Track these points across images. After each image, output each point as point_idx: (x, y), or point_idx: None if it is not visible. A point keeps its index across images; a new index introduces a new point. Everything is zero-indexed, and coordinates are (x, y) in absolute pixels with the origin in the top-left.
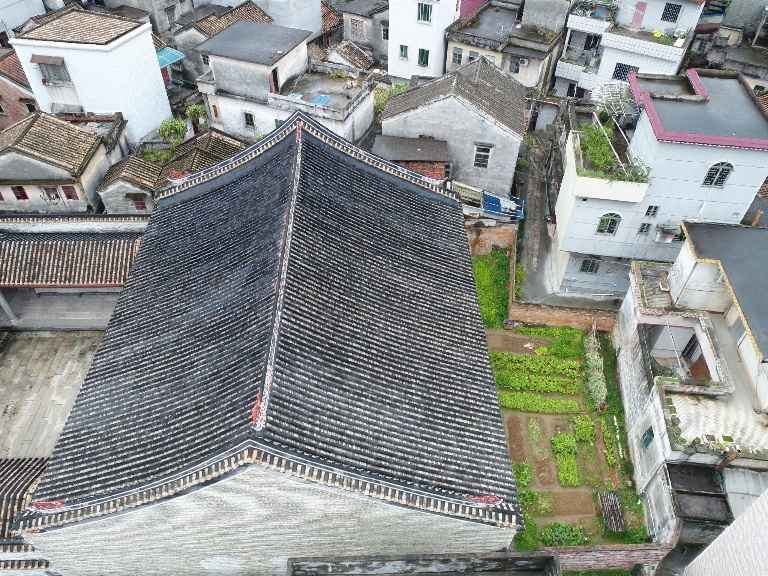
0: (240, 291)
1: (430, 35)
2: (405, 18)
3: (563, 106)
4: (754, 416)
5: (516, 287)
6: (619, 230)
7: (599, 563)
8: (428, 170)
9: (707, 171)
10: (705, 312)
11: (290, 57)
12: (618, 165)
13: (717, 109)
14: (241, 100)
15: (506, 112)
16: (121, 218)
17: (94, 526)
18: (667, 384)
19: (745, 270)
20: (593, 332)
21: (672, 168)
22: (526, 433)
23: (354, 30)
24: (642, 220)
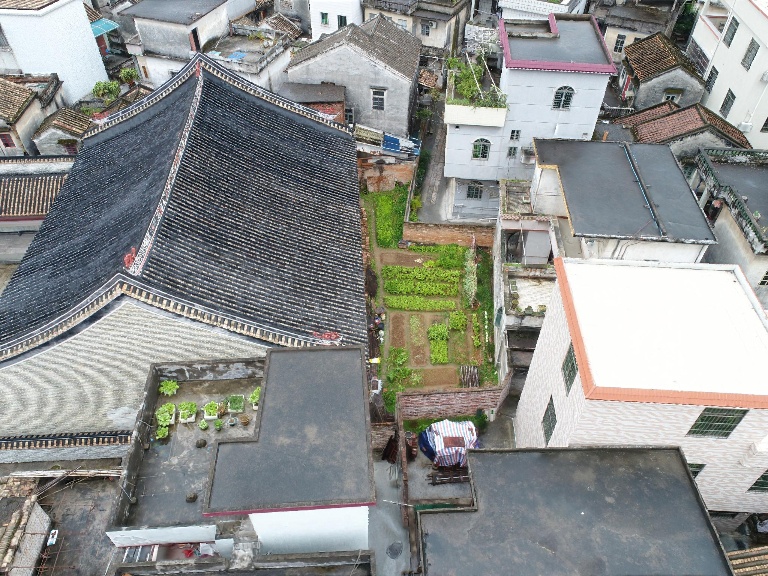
0: (140, 196)
1: (346, 2)
2: None
3: None
4: None
5: (412, 214)
6: (491, 154)
7: (446, 409)
8: (328, 111)
9: (554, 95)
10: (554, 215)
11: (210, 19)
12: (479, 93)
13: (564, 43)
14: (166, 59)
15: (398, 59)
16: (52, 159)
17: (9, 372)
18: (512, 269)
19: (577, 172)
20: (473, 245)
21: (524, 94)
22: (407, 327)
23: (283, 3)
24: (508, 144)
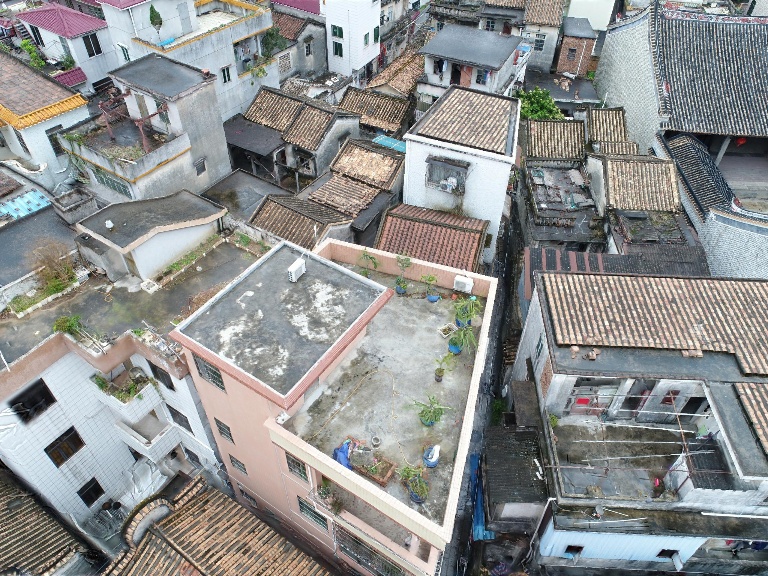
0: None
1: None
2: (365, 8)
3: (446, 6)
4: (704, 8)
5: None
6: None
7: None
8: None
9: None
10: None
11: None
12: None
13: None
14: None
15: None
16: None
17: None
18: None
19: None
20: None
21: None
22: None
23: (282, 68)
24: None
